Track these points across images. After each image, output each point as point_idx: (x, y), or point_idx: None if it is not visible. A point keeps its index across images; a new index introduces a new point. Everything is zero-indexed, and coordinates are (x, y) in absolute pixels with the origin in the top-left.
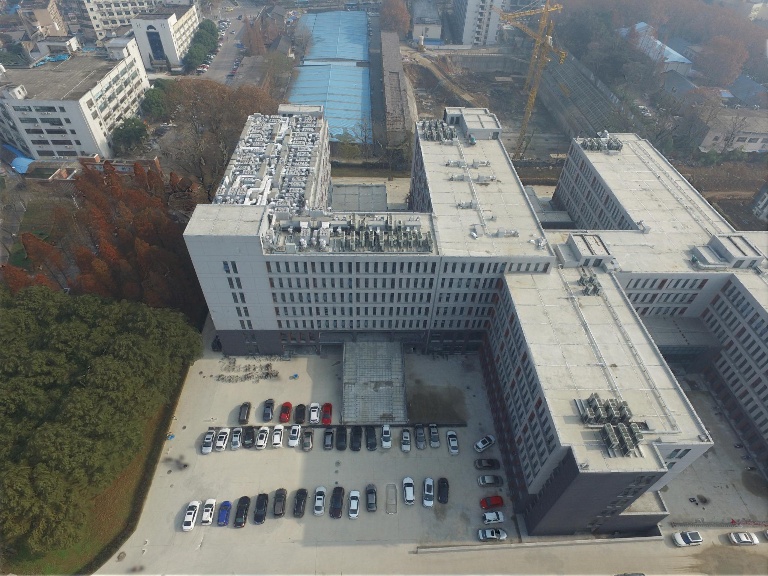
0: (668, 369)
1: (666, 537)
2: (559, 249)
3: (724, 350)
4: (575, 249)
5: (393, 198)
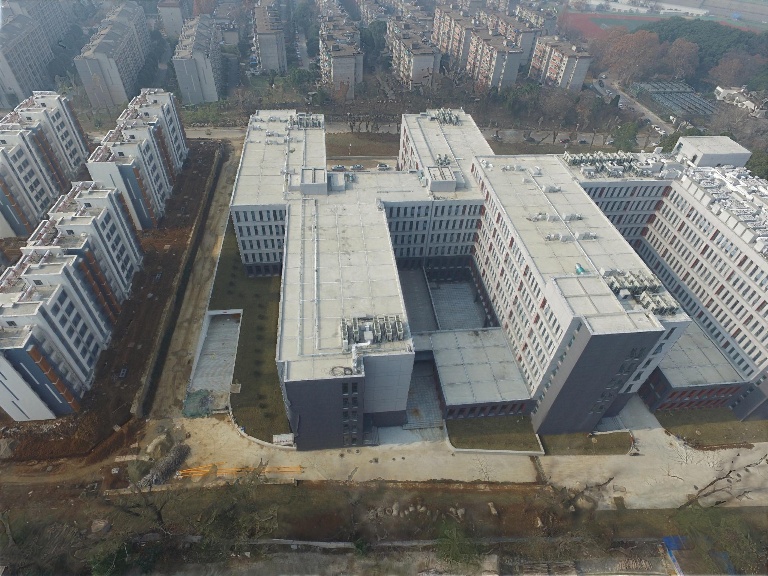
0: None
1: (392, 169)
2: None
3: None
4: None
5: (656, 440)
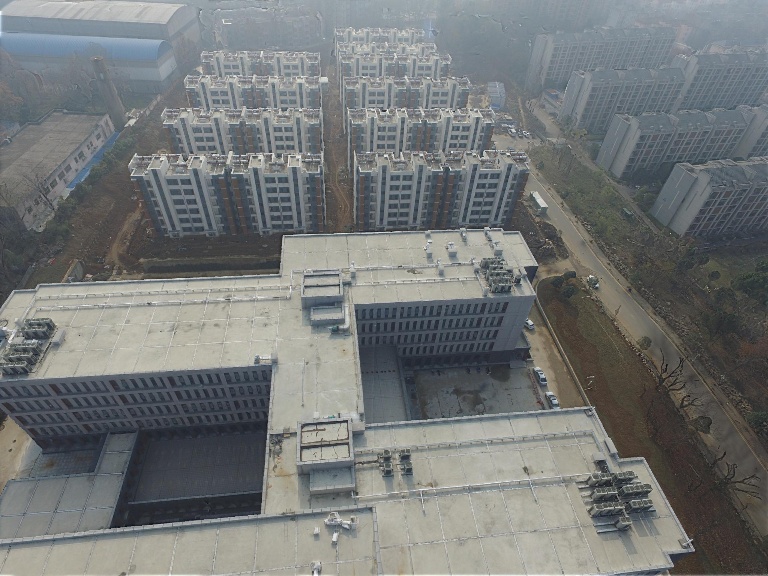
0: (516, 415)
1: None
2: (324, 490)
3: (399, 345)
4: (330, 465)
5: None
